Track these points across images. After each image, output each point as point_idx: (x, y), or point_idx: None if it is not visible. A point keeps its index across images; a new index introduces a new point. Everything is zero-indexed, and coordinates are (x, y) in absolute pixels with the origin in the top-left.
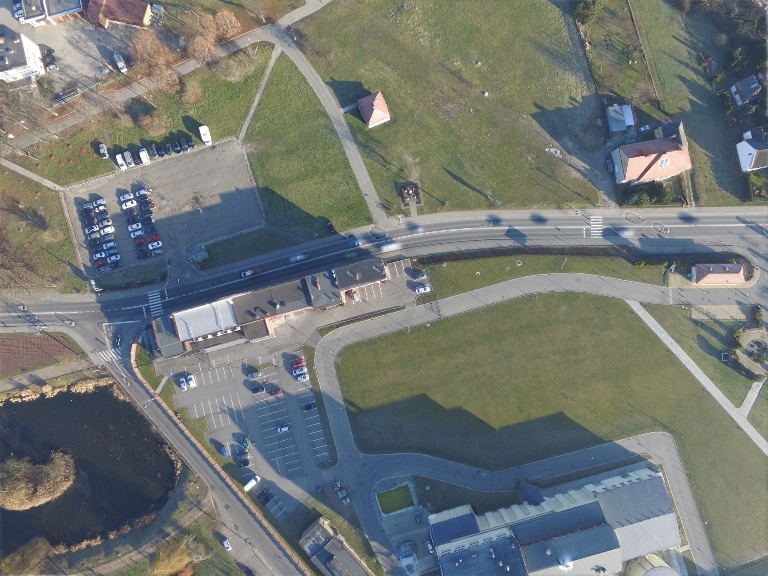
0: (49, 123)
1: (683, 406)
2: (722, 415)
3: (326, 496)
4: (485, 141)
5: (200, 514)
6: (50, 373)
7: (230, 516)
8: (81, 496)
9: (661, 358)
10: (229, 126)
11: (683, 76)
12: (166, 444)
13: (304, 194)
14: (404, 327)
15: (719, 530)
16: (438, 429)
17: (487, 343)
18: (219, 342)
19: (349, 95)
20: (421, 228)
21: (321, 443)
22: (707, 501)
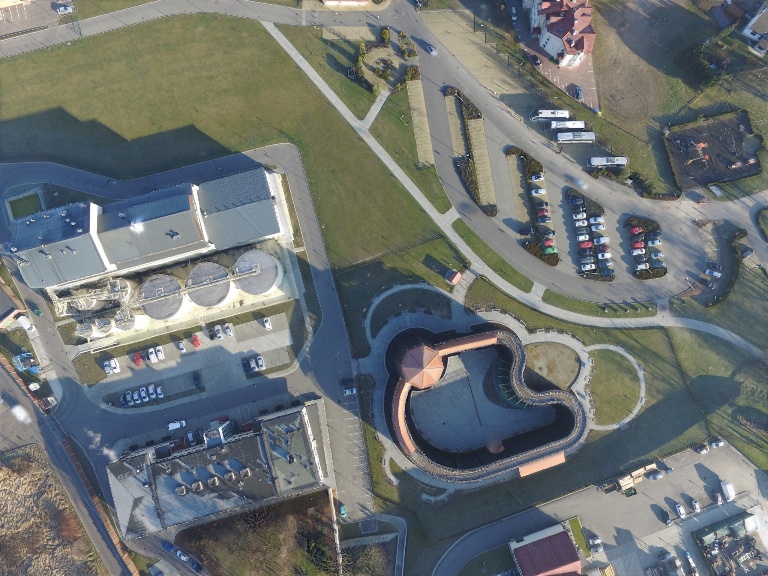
0: None
1: (309, 119)
2: (345, 127)
3: None
4: None
5: None
6: None
7: None
8: None
9: (290, 74)
10: None
11: None
12: None
13: None
14: (45, 46)
15: (334, 233)
16: (71, 140)
17: (124, 60)
18: None
19: None
20: None
21: None
22: (325, 206)
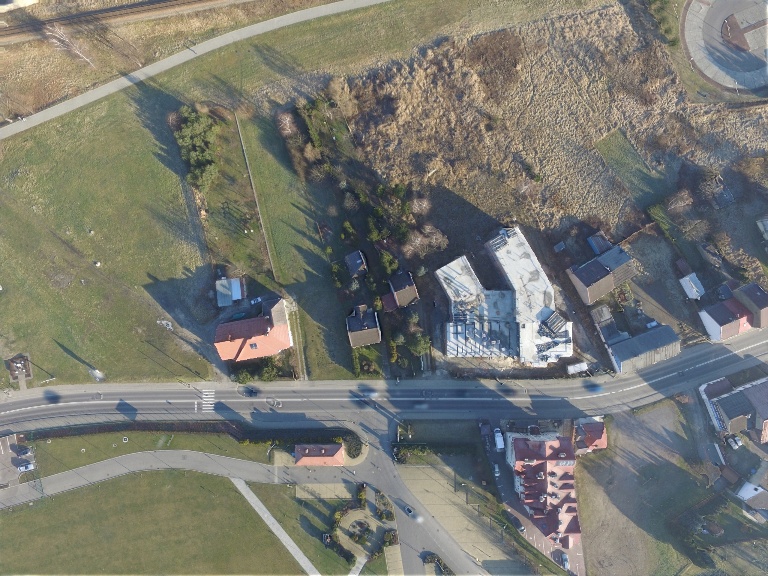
0: None
1: None
2: None
3: None
4: (95, 313)
5: None
6: None
7: None
8: None
9: (262, 539)
10: None
11: (299, 246)
12: None
13: None
14: (6, 506)
15: None
16: None
17: (89, 523)
18: None
19: None
20: (30, 402)
21: None
22: None
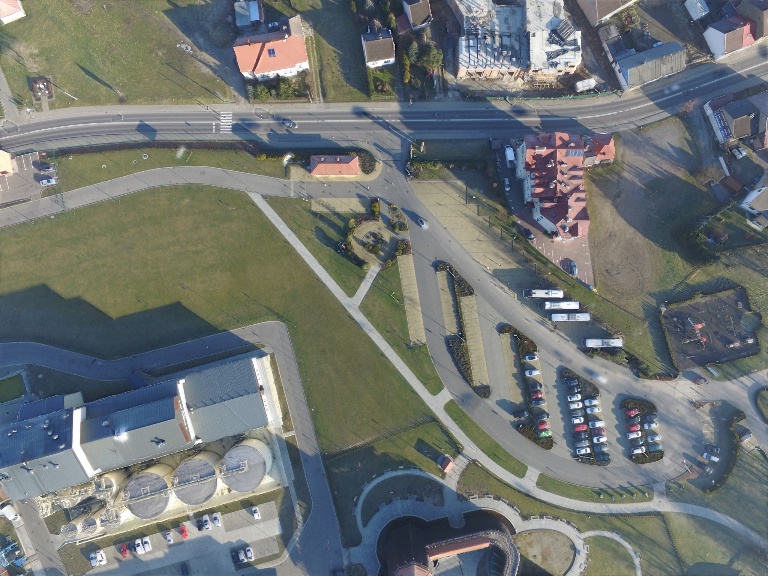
0: None
1: (298, 296)
2: (335, 304)
3: None
4: (116, 37)
5: None
6: None
7: None
8: None
9: (278, 249)
10: None
11: None
12: None
13: None
14: (28, 219)
15: (324, 416)
16: (55, 319)
17: (109, 234)
18: None
19: None
20: (53, 123)
21: None
22: (315, 388)
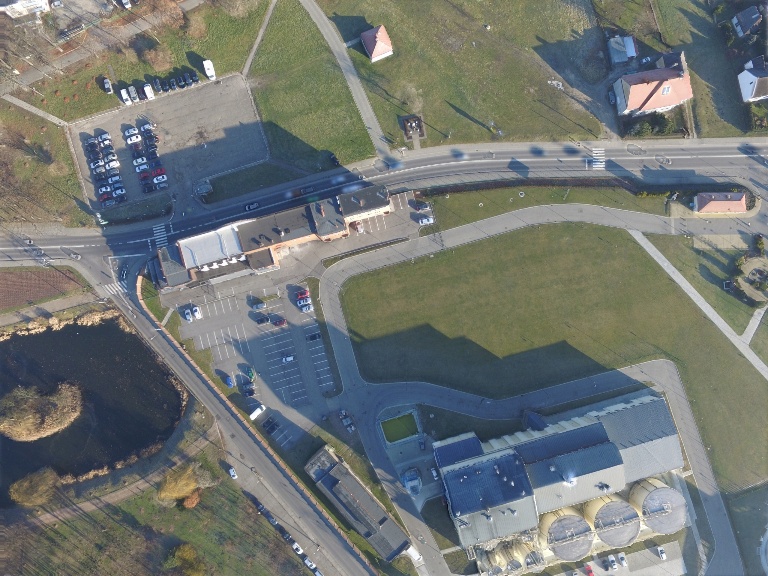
0: (54, 59)
1: (685, 334)
2: (724, 342)
3: (331, 425)
4: (487, 74)
5: (206, 443)
6: (56, 306)
7: (236, 445)
8: (88, 427)
9: (663, 287)
10: (233, 61)
11: (684, 9)
12: (172, 375)
13: (308, 128)
14: (408, 258)
15: (722, 455)
16: (442, 358)
17: (490, 273)
18: (224, 272)
19: (352, 30)
20: (424, 161)
21: (326, 373)
22: (709, 427)
